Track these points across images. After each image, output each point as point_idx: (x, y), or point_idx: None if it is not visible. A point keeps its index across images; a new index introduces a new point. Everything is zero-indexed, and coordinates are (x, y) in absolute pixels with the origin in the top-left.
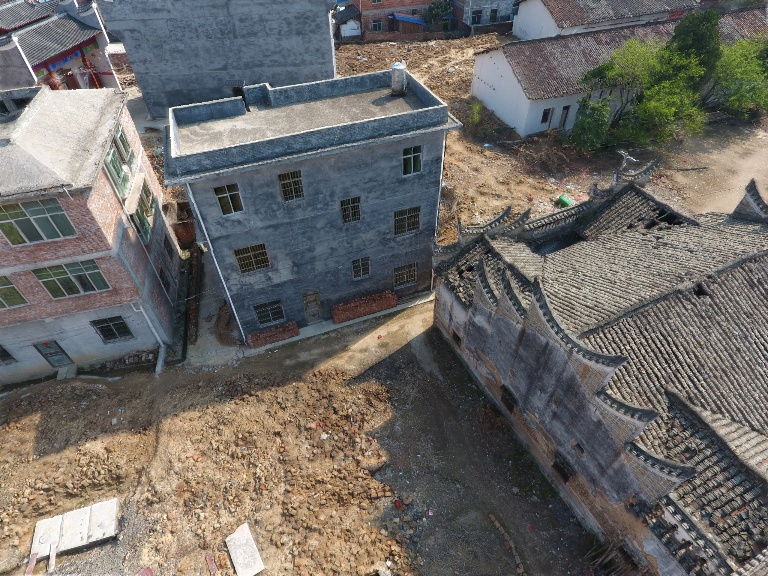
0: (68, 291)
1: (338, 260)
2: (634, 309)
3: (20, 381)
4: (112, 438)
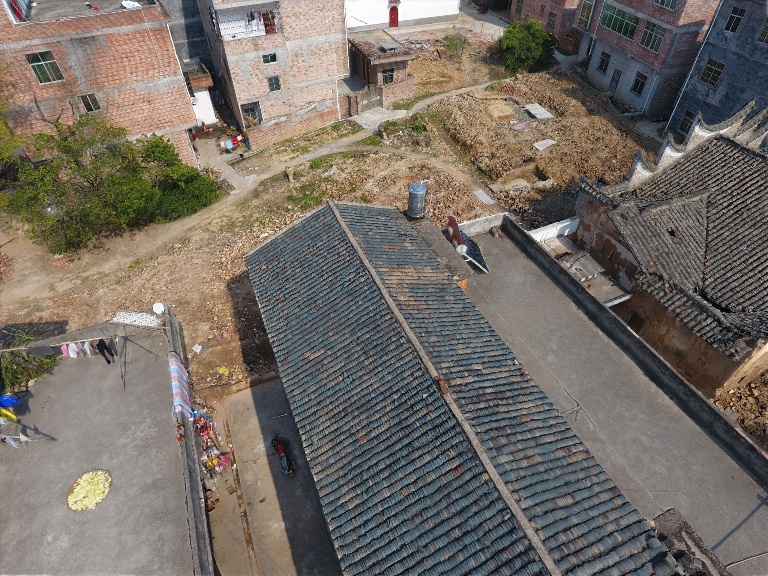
0: (646, 43)
1: (750, 114)
2: None
3: (597, 87)
4: (580, 106)
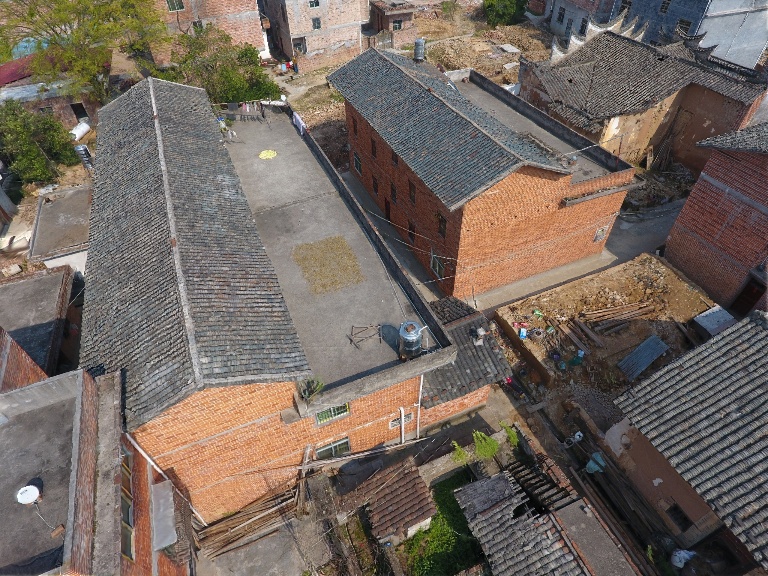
0: None
1: (647, 34)
2: (633, 40)
3: None
4: None
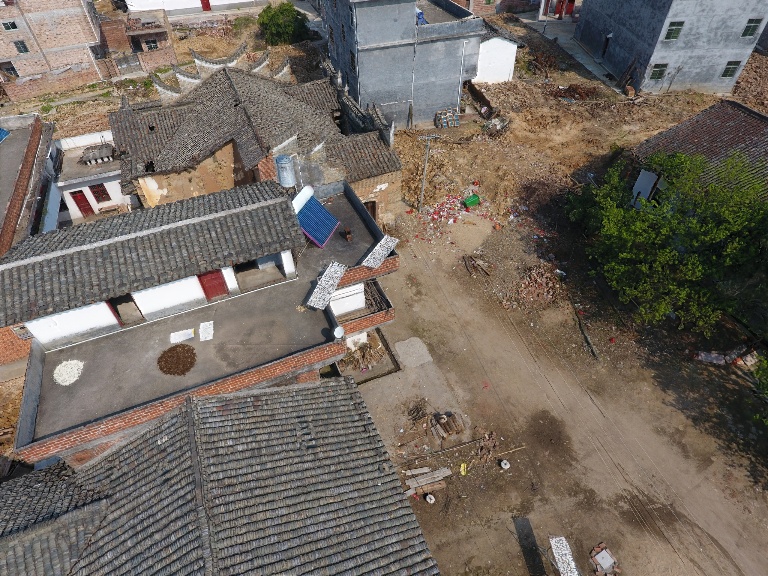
0: None
1: None
2: None
3: None
4: None
